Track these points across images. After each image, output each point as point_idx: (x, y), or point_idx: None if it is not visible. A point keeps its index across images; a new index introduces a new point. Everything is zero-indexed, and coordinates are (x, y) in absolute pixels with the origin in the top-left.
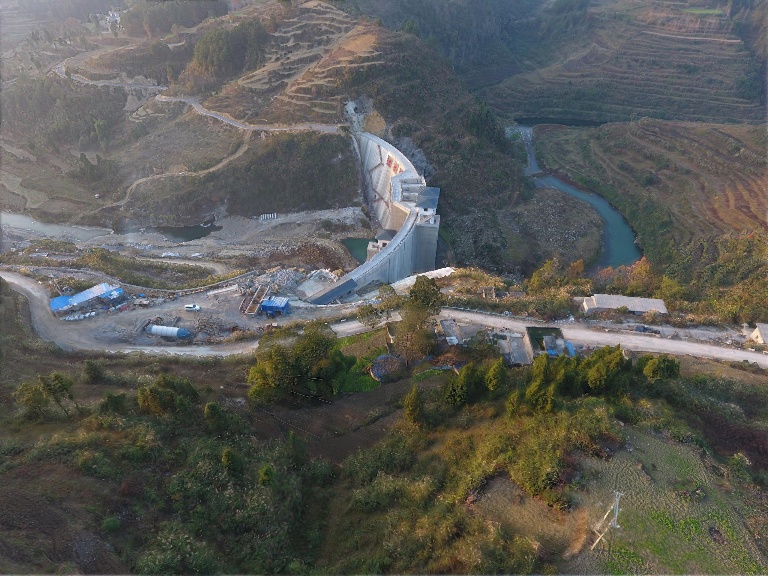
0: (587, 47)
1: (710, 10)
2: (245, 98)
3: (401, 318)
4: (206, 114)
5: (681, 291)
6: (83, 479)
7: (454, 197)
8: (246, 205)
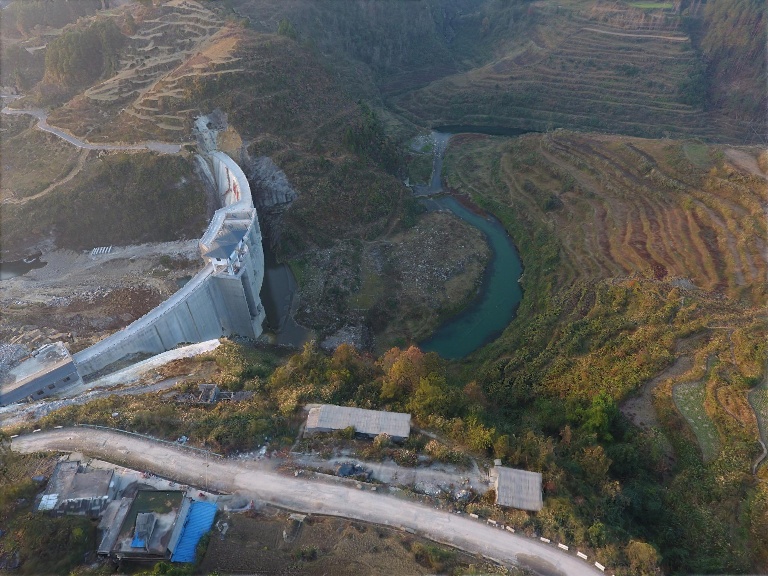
0: (525, 45)
1: (659, 4)
2: (89, 111)
3: (42, 445)
4: (45, 130)
5: (438, 401)
6: None
7: (316, 227)
8: (76, 237)
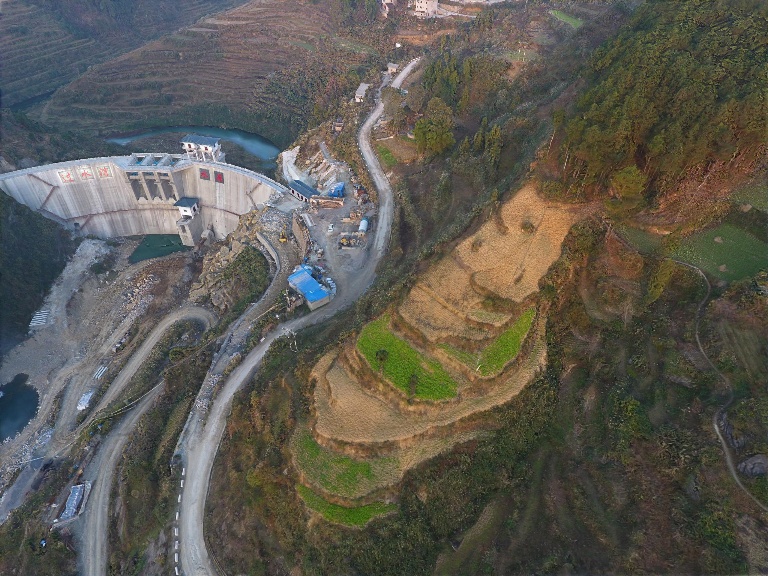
0: None
1: None
2: None
3: (366, 141)
4: None
5: None
6: (541, 109)
7: None
8: (0, 335)
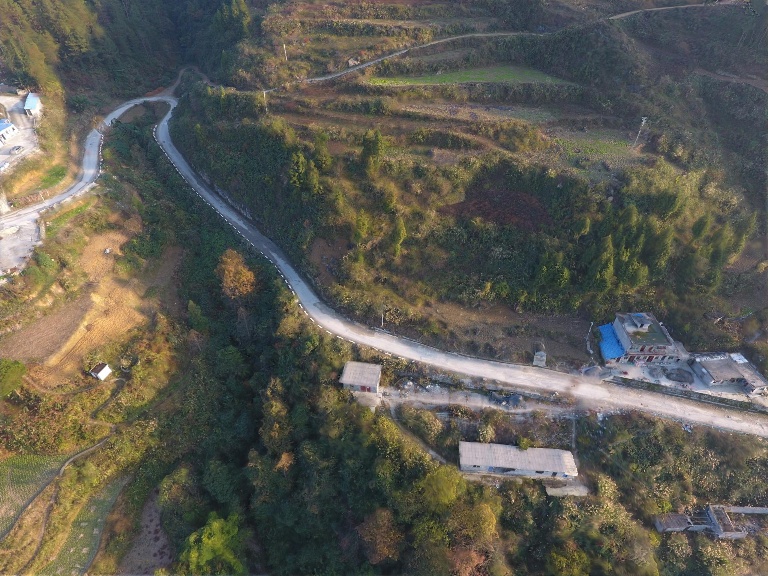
0: None
1: None
2: None
3: None
4: None
5: None
6: None
7: None
8: None
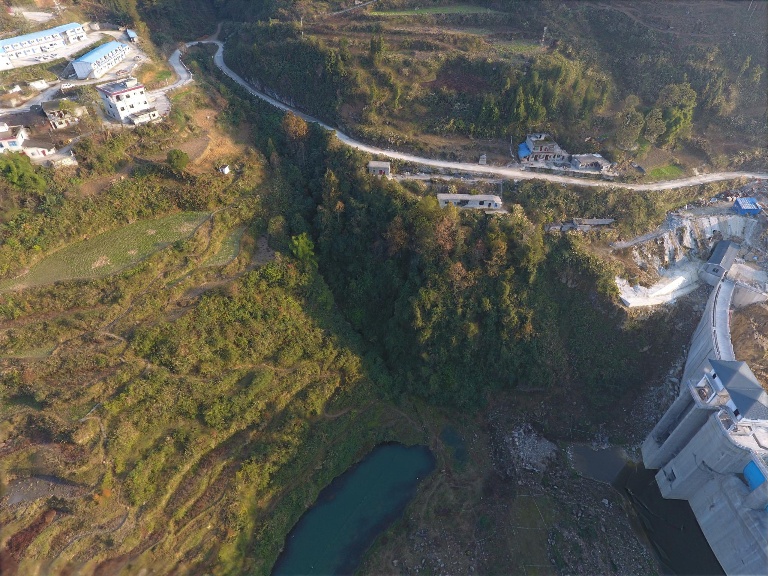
0: None
1: None
2: None
3: (640, 187)
4: None
5: None
6: None
7: None
8: None
